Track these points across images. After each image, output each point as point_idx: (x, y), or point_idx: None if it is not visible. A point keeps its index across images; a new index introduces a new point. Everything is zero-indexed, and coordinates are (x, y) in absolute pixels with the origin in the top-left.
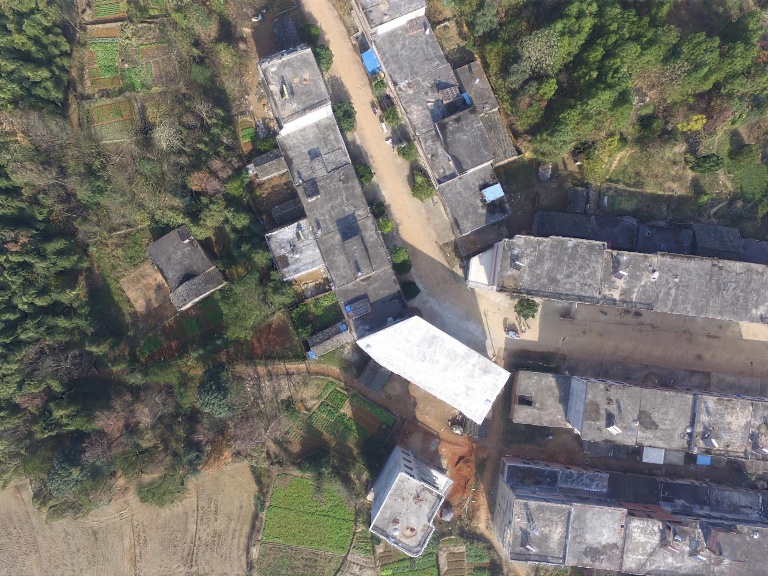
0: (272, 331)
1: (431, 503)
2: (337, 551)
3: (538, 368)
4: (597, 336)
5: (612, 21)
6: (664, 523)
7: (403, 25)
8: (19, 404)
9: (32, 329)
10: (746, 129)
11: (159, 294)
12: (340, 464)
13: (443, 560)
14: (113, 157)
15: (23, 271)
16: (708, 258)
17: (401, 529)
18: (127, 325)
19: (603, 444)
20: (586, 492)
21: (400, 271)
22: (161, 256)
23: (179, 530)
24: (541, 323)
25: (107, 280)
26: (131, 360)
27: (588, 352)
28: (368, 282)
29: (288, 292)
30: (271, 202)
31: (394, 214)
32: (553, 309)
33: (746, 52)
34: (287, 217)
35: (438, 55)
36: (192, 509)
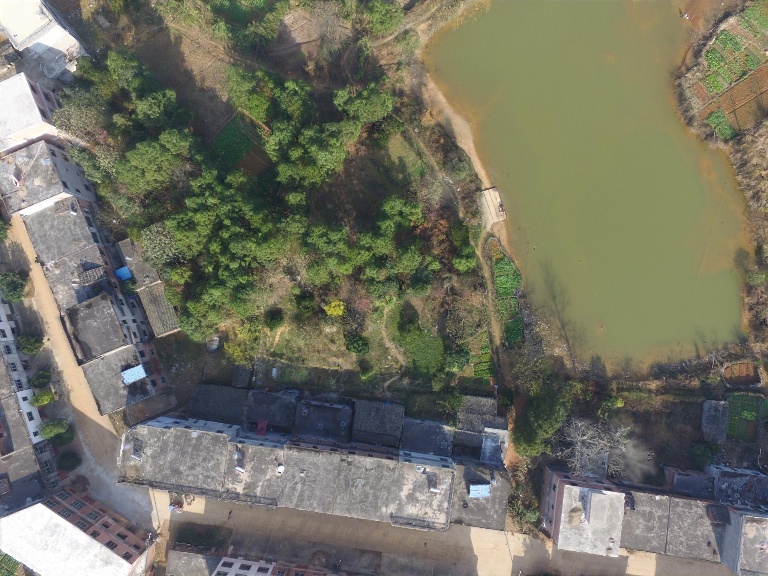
0: None
1: None
2: None
3: (200, 543)
4: (264, 511)
5: (225, 217)
6: None
7: (52, 206)
8: None
9: None
10: (420, 301)
11: None
12: None
13: None
14: None
15: None
16: (337, 453)
17: None
18: None
19: None
20: None
21: (58, 443)
22: None
23: None
24: None
25: None
26: None
27: (255, 527)
28: (9, 461)
29: None
30: None
31: (66, 380)
32: None
33: (372, 244)
34: None
35: (85, 235)
36: None
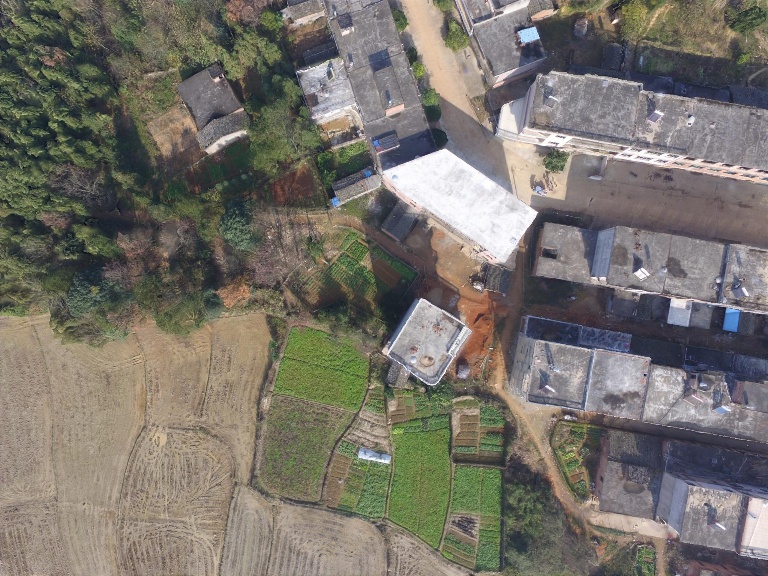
0: (296, 180)
1: (451, 333)
2: (349, 407)
3: None
4: (626, 198)
5: None
6: (689, 374)
7: None
8: (43, 221)
9: (60, 147)
10: None
11: (186, 138)
12: (357, 315)
13: (456, 422)
14: (148, 1)
15: (55, 88)
16: (746, 106)
17: (419, 357)
18: (152, 168)
19: (627, 303)
20: None
21: (429, 117)
22: (191, 94)
23: (191, 378)
24: (569, 182)
25: (135, 122)
26: (154, 199)
27: (616, 214)
28: (397, 119)
29: (316, 132)
30: (303, 49)
31: (425, 65)
32: (582, 169)
33: None
34: (318, 61)
35: None
36: (205, 358)
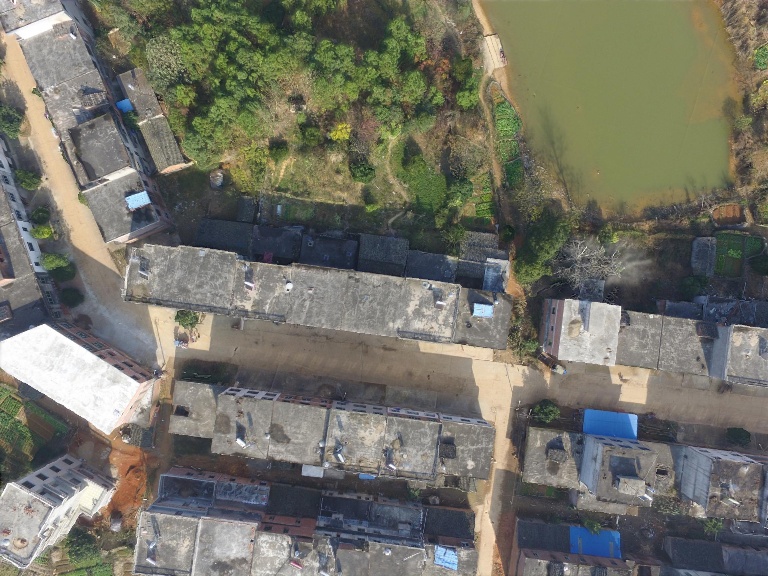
0: None
1: (43, 514)
2: None
3: (206, 378)
4: (270, 347)
5: (232, 28)
6: (293, 538)
7: (50, 30)
8: None
9: None
10: (424, 139)
11: None
12: (11, 471)
13: (119, 570)
14: None
15: None
16: (344, 270)
17: (12, 540)
18: None
19: None
20: (243, 505)
21: (59, 278)
22: None
23: None
24: (213, 332)
25: None
26: None
27: (260, 363)
28: (10, 289)
29: None
30: None
31: (66, 220)
32: (225, 319)
33: (380, 61)
34: None
35: (85, 60)
36: None
